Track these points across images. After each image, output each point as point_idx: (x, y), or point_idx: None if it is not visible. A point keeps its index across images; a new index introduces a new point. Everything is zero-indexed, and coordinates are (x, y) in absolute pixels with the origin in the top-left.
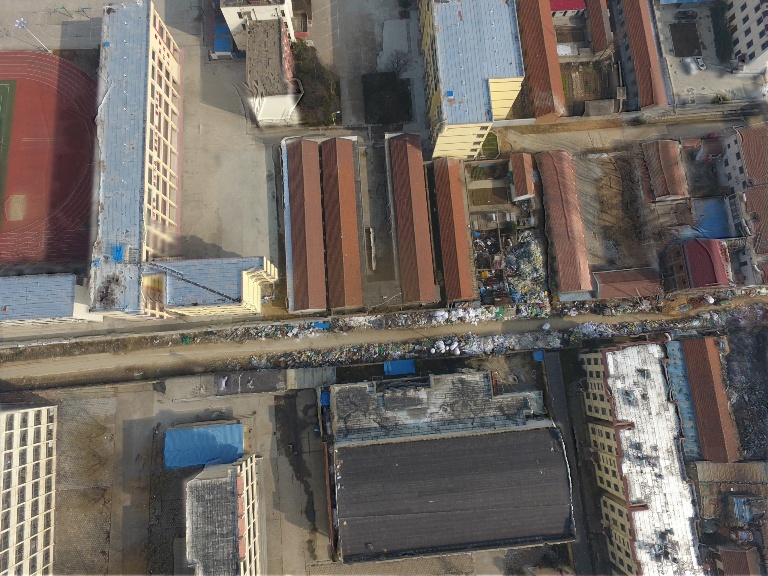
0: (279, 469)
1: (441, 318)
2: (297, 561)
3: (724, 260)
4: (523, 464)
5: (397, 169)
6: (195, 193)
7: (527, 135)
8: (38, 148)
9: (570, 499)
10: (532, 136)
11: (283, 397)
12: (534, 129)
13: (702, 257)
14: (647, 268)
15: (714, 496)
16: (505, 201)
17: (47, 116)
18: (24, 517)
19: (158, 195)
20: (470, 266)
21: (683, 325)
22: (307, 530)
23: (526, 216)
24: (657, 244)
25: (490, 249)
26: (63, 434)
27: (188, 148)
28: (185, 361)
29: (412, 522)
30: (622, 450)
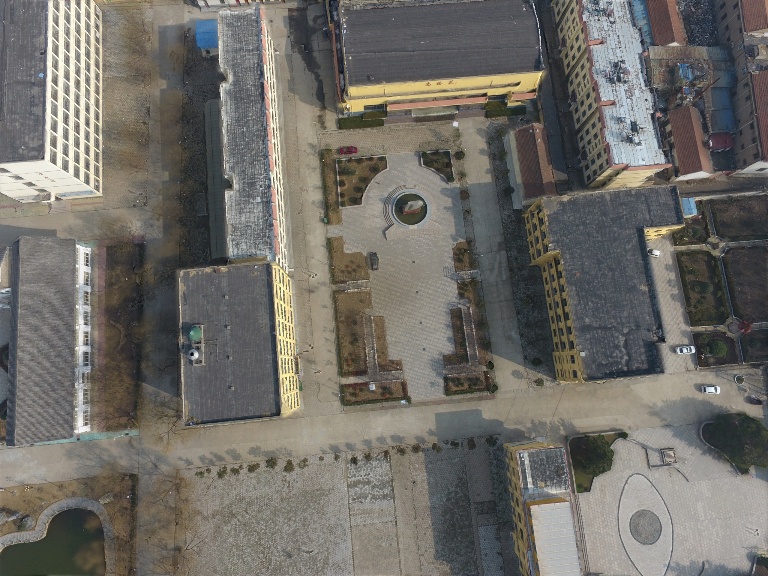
0: (293, 63)
1: None
2: (309, 130)
3: None
4: (500, 18)
5: None
6: None
7: None
8: None
9: (539, 43)
10: None
11: (296, 10)
12: None
13: None
14: None
15: (663, 68)
16: None
17: None
18: (80, 63)
19: None
20: None
21: None
22: (318, 108)
23: None
24: None
25: None
26: (107, 35)
27: None
28: None
29: (407, 59)
30: (583, 5)
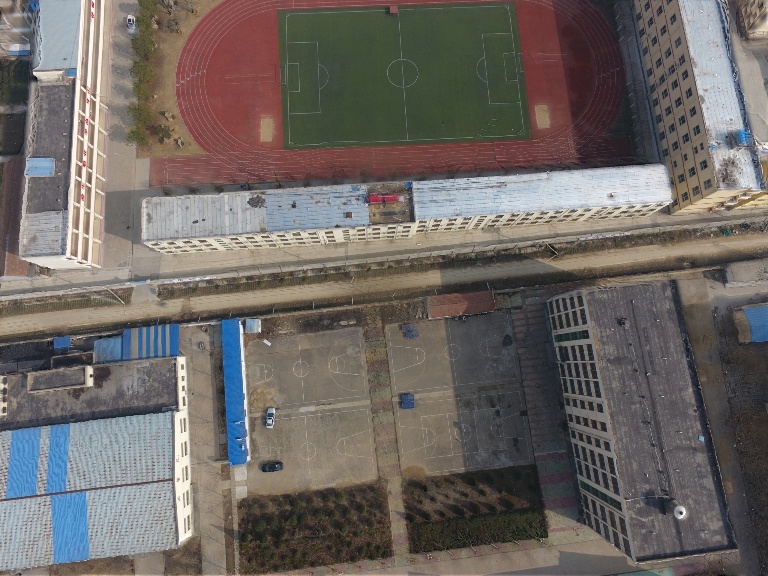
0: None
1: None
2: None
3: None
4: None
5: None
6: None
7: None
8: (554, 62)
9: None
10: None
11: None
12: None
13: None
14: None
15: None
16: None
17: (560, 32)
18: None
19: None
20: None
21: None
22: None
23: None
24: None
25: None
26: None
27: (734, 51)
28: (729, 251)
29: None
30: None
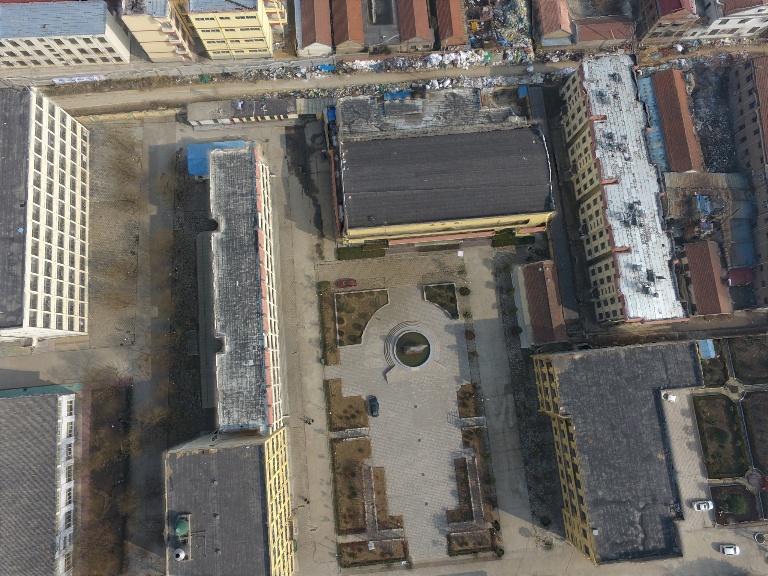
0: (290, 186)
1: (435, 60)
2: (307, 261)
3: None
4: (508, 152)
5: None
6: None
7: None
8: None
9: (549, 180)
10: None
11: (293, 128)
12: None
13: None
14: (621, 15)
15: (679, 198)
16: None
17: None
18: (64, 199)
19: None
20: (461, 14)
21: (654, 68)
22: (315, 236)
23: None
24: None
25: (479, 4)
26: (95, 156)
27: None
28: (204, 97)
29: (409, 198)
30: (596, 139)
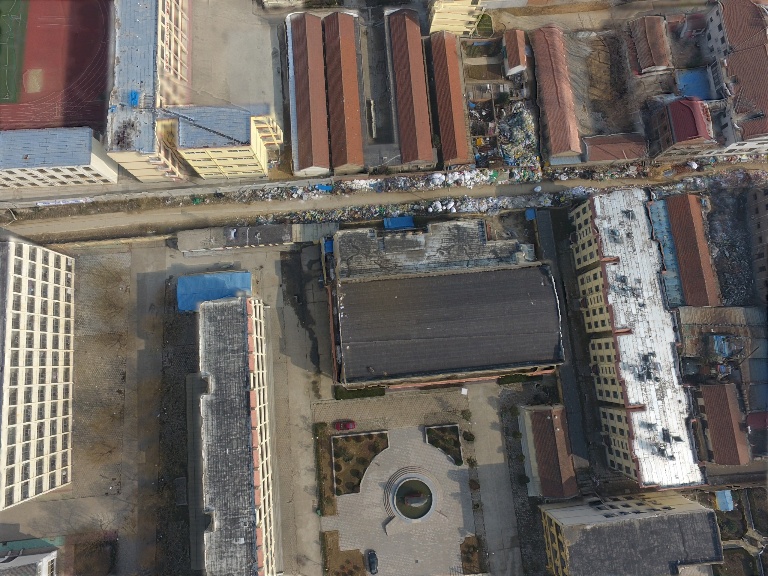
0: (285, 317)
1: (438, 180)
2: (302, 400)
3: (706, 120)
4: (515, 296)
5: (396, 42)
6: (204, 60)
7: (520, 17)
8: (54, 25)
9: (559, 327)
10: (525, 18)
11: (288, 253)
12: (527, 11)
13: (684, 113)
14: (633, 133)
15: (695, 336)
16: (499, 76)
17: None
18: (46, 346)
19: (170, 53)
20: (466, 131)
21: (668, 188)
22: (312, 372)
23: (519, 88)
24: (643, 112)
25: (485, 118)
26: (80, 285)
27: (198, 16)
28: (195, 220)
29: (411, 347)
30: (608, 283)
